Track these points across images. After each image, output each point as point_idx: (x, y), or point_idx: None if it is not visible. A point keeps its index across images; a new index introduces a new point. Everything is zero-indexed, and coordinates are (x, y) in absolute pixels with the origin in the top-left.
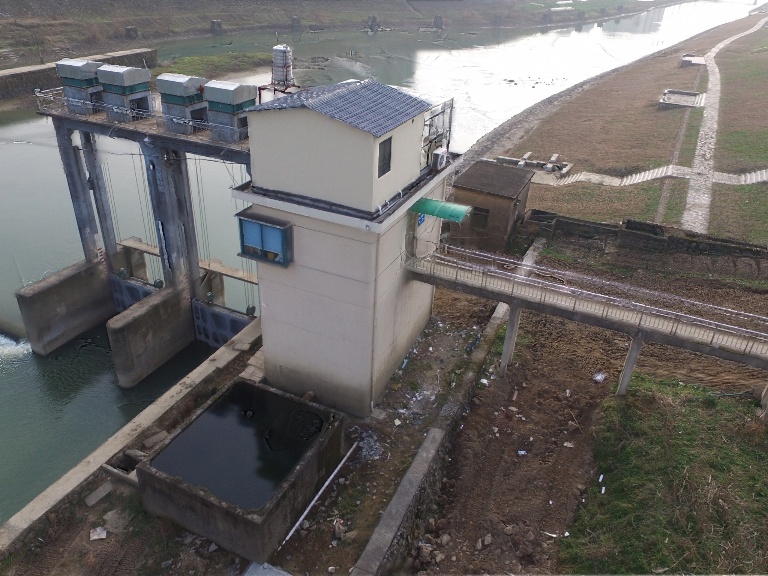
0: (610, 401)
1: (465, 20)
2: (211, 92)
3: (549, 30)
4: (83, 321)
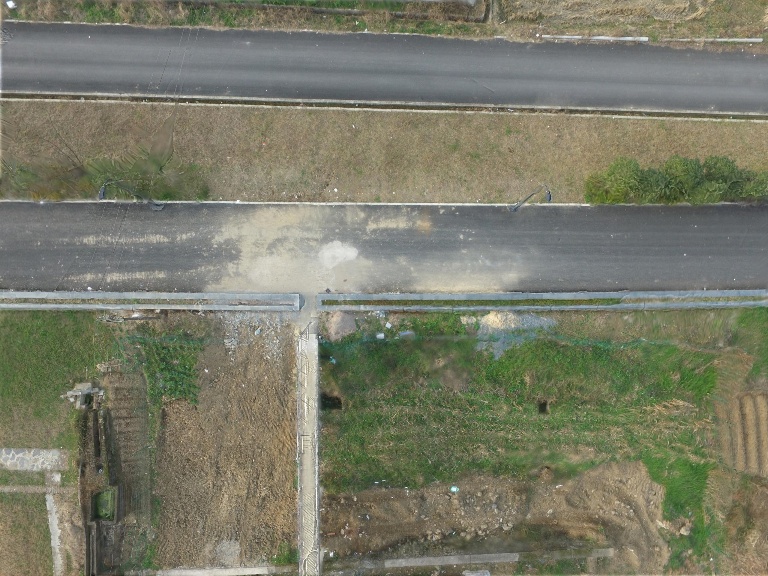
0: (330, 491)
1: None
2: None
3: None
4: None
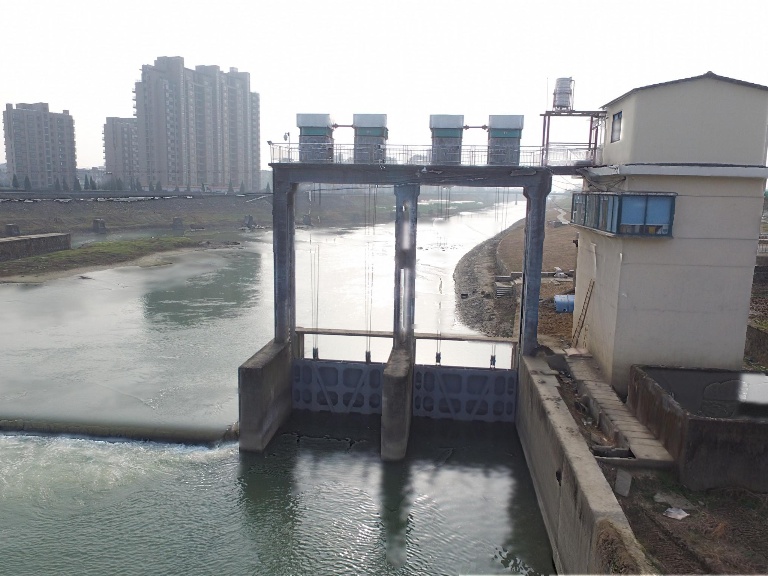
0: None
1: (329, 219)
2: (498, 119)
3: (423, 215)
4: (279, 414)
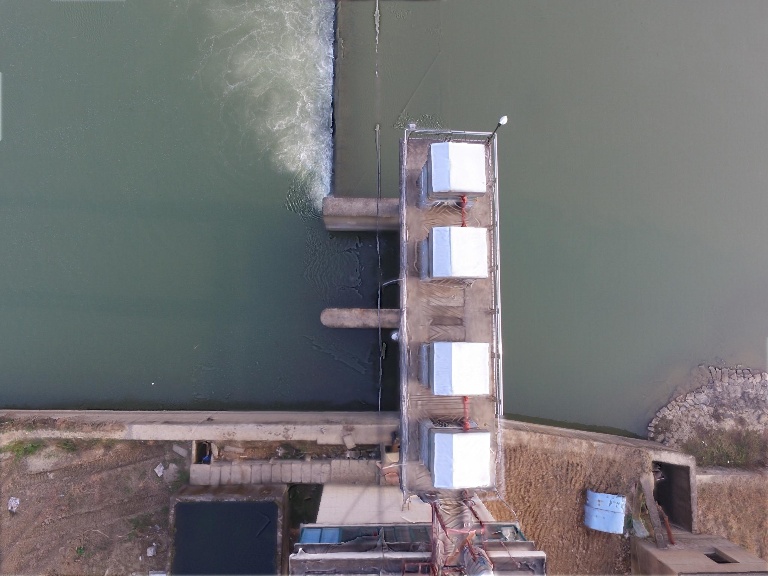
0: None
1: None
2: (432, 444)
3: None
4: (370, 228)
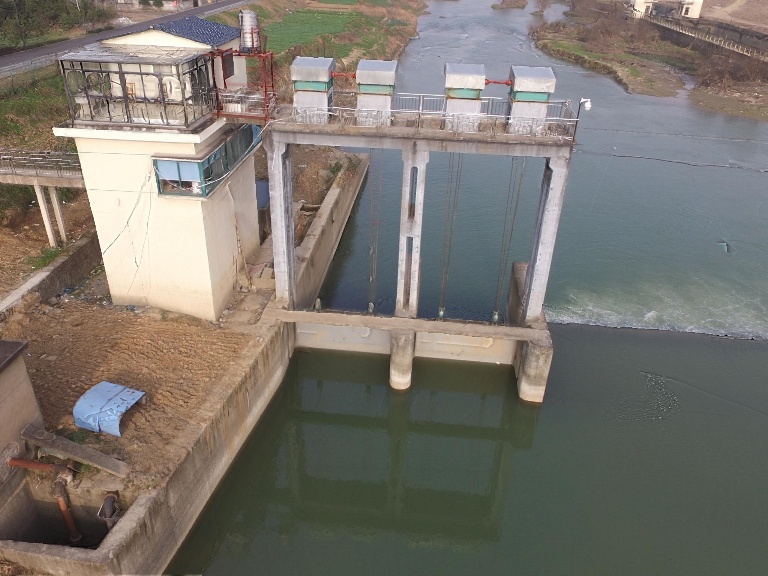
0: None
1: None
2: None
3: None
4: None
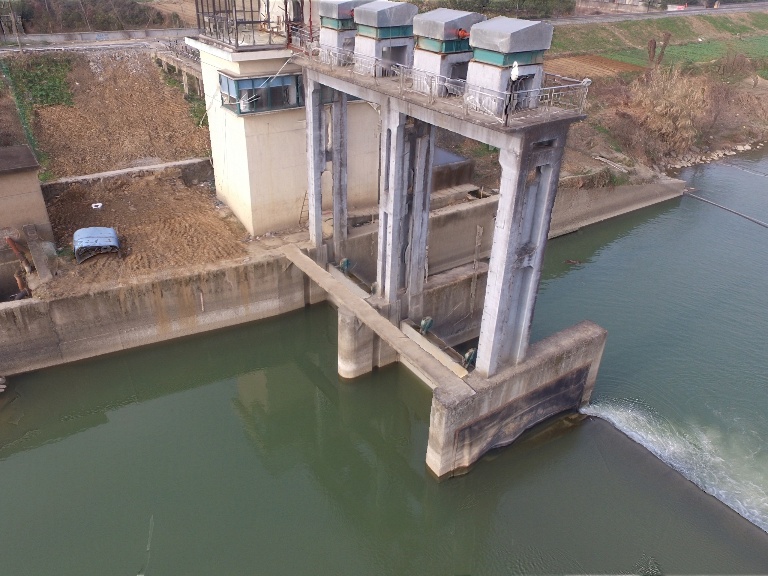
0: None
1: None
2: None
3: None
4: None
